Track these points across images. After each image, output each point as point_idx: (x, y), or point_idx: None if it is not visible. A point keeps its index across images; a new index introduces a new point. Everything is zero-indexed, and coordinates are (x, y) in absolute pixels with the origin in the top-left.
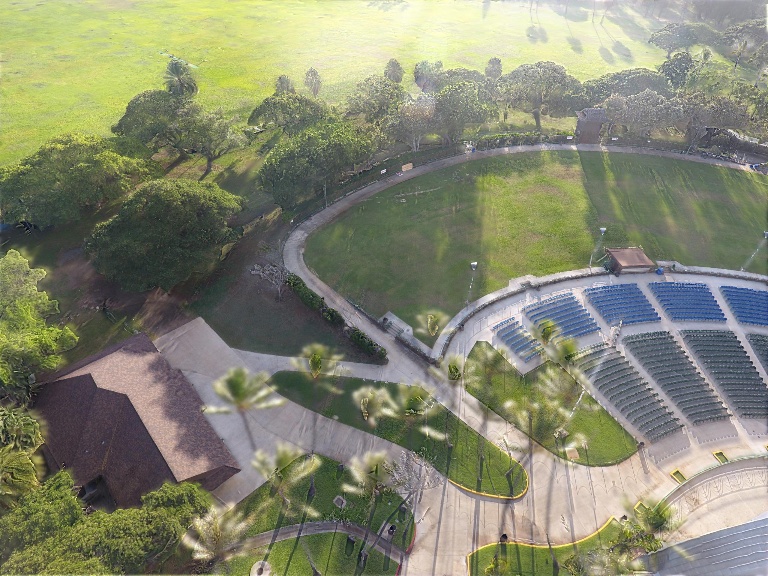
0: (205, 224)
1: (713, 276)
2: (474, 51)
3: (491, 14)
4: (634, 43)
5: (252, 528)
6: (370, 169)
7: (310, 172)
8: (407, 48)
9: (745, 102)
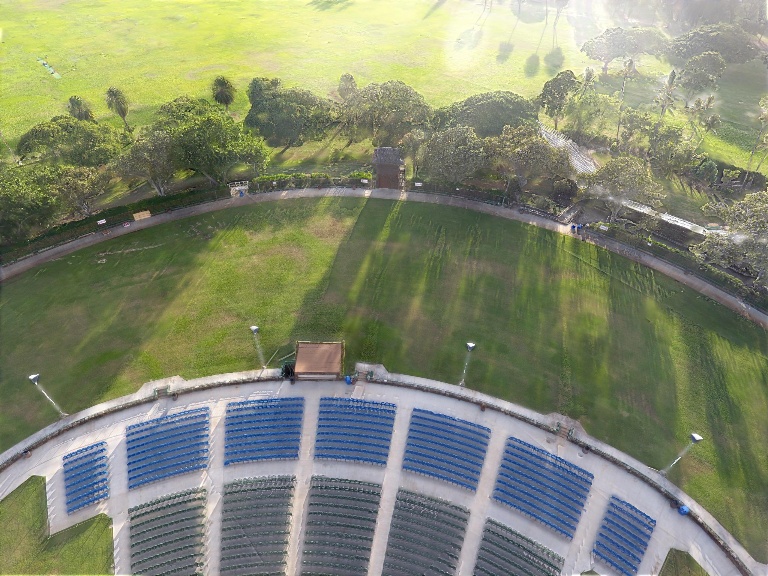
0: None
1: (419, 390)
2: (379, 59)
3: (436, 14)
4: (576, 50)
5: None
6: (82, 219)
7: None
8: (306, 55)
9: (637, 133)
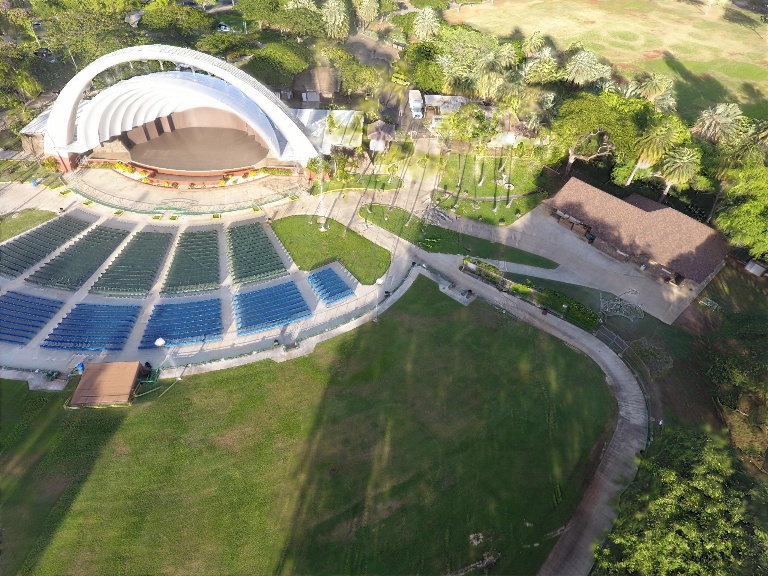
0: (767, 357)
1: None
2: None
3: None
4: None
5: (522, 200)
6: None
7: None
8: None
9: None
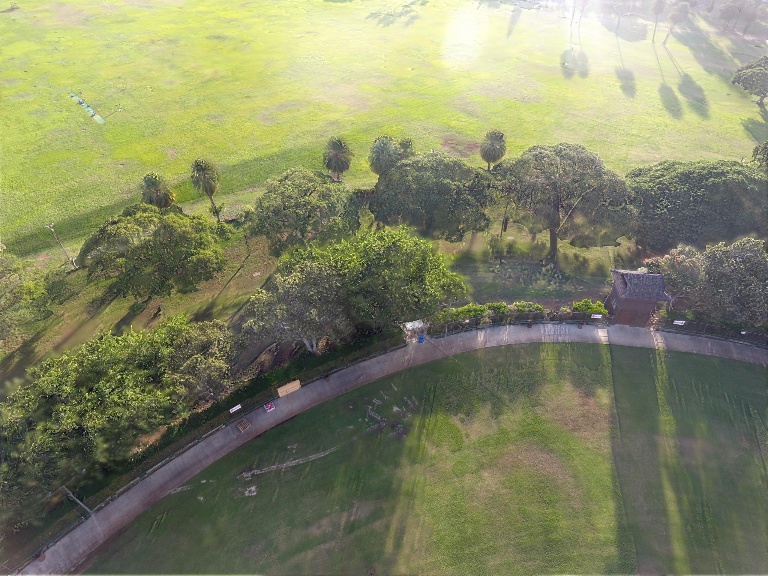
0: None
1: None
2: (483, 92)
3: (519, 30)
4: (710, 77)
5: None
6: (207, 408)
7: (5, 504)
8: (394, 87)
9: None
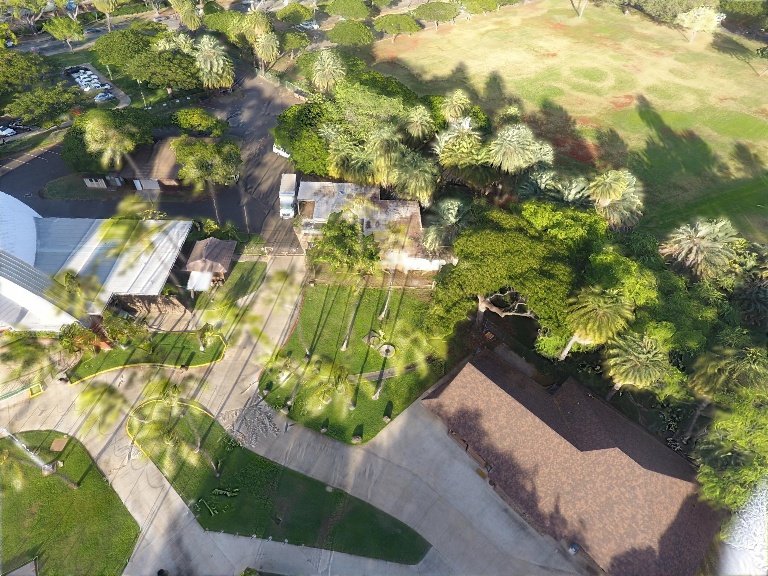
0: None
1: None
2: None
3: None
4: None
5: (402, 379)
6: None
7: None
8: None
9: None
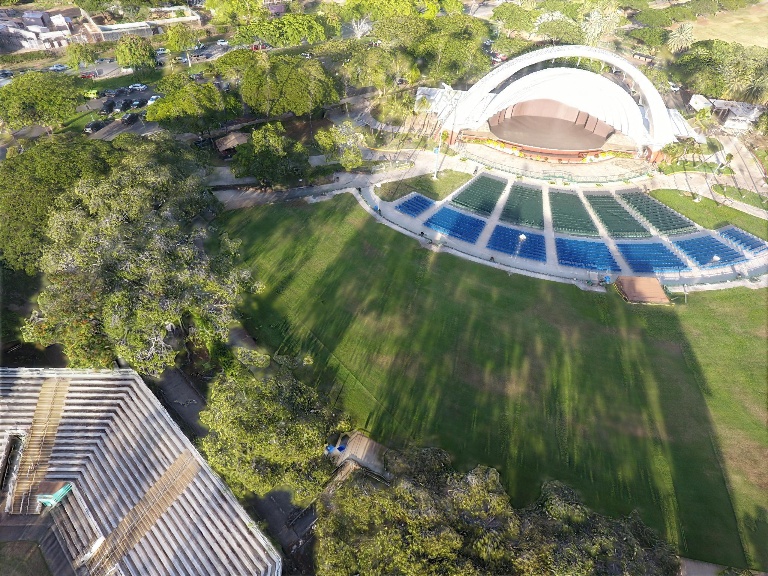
0: None
1: None
2: None
3: None
4: None
5: None
6: None
7: None
8: None
9: None
